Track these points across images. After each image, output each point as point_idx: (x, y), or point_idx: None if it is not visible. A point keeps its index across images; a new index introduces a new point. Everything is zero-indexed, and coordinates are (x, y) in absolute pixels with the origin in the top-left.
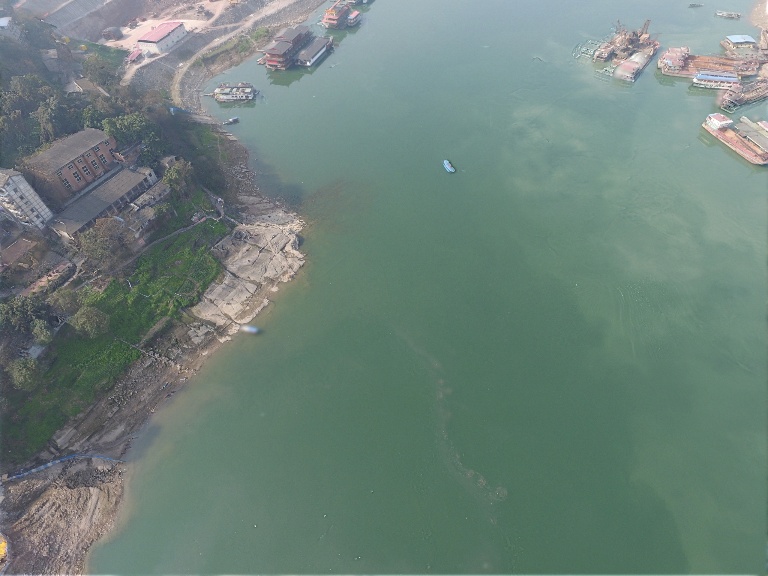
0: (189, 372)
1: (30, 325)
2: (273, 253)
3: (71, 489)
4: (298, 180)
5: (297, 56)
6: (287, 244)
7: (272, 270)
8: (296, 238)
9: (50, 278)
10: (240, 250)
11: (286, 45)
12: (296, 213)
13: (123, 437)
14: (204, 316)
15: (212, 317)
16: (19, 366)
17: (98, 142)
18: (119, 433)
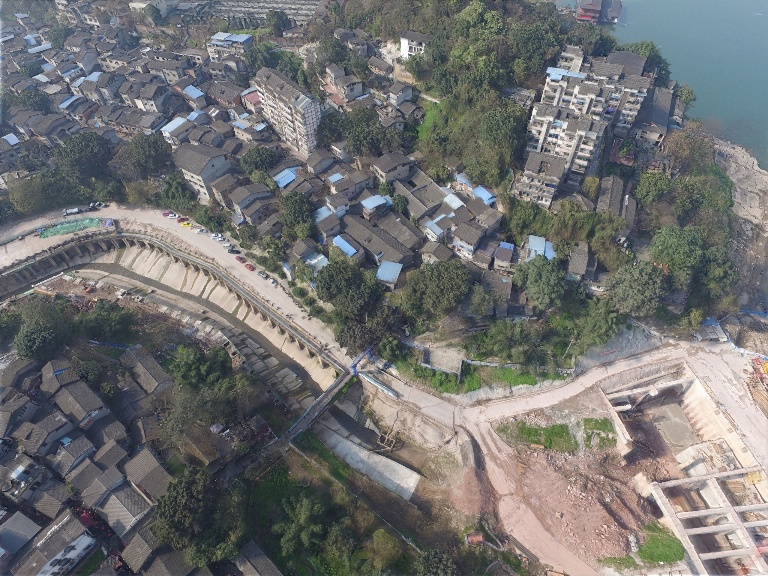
0: (762, 257)
1: (699, 201)
2: (752, 170)
3: (762, 333)
4: (705, 116)
5: (606, 13)
6: (754, 164)
7: (761, 184)
8: (756, 160)
9: (656, 171)
10: (731, 166)
11: (598, 2)
12: (730, 142)
13: (752, 301)
14: (742, 215)
15: (747, 216)
16: (723, 230)
17: (643, 62)
18: (748, 298)
